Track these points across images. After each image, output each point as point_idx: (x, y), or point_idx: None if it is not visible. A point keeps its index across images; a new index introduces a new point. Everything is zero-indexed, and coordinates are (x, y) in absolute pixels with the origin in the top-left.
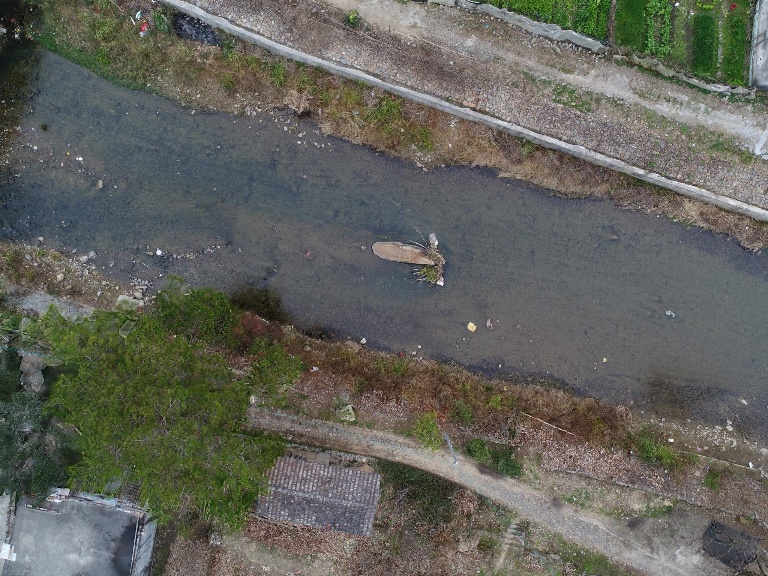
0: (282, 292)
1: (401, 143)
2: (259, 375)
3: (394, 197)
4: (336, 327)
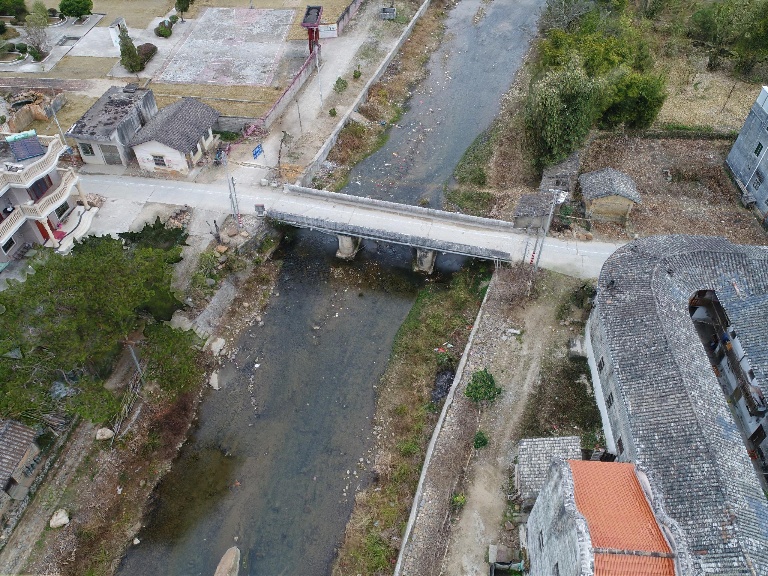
0: (205, 461)
1: (346, 575)
2: (96, 388)
3: (289, 572)
4: (159, 513)
